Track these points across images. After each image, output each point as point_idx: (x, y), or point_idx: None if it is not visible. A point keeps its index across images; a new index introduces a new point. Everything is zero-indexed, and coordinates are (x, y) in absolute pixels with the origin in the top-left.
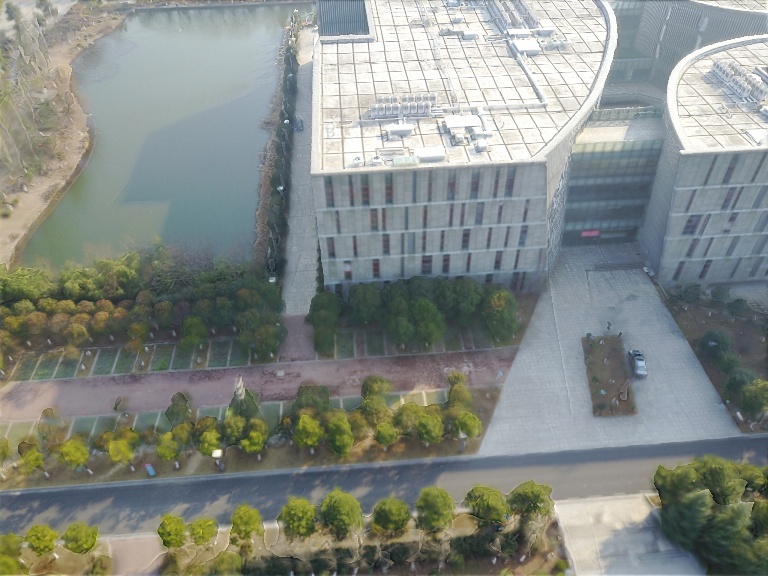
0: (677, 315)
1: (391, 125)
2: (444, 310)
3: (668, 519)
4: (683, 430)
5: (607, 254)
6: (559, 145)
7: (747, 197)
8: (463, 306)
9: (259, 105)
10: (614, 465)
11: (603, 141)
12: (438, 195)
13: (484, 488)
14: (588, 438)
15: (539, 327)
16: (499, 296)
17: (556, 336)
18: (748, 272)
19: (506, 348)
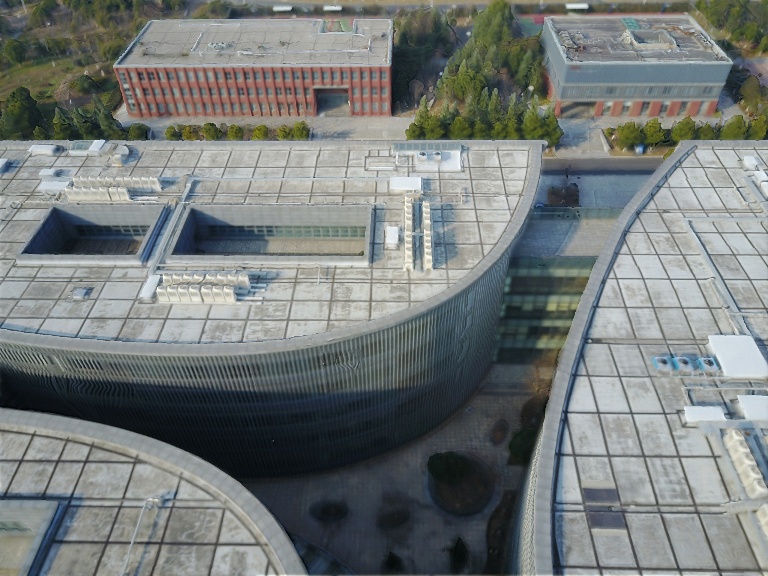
0: None
1: None
2: None
3: None
4: None
5: None
6: None
7: None
8: None
9: None
10: None
11: (603, 208)
12: None
13: (659, 136)
14: (585, 179)
15: None
16: None
17: None
18: None
19: None
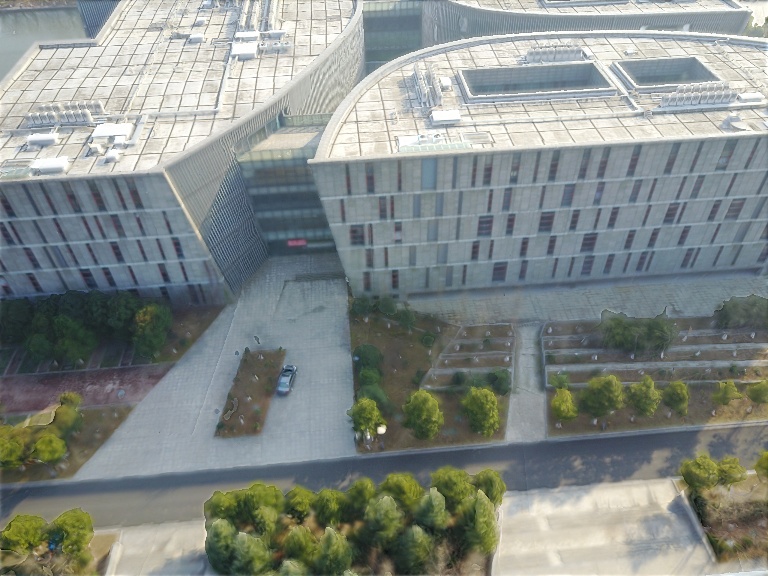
0: (352, 327)
1: (34, 135)
2: (91, 326)
3: (205, 548)
4: (298, 450)
5: (315, 263)
6: (196, 154)
7: (402, 206)
8: (109, 321)
9: None
10: (206, 488)
11: (268, 149)
12: (62, 208)
13: (25, 516)
14: (195, 459)
15: (208, 341)
16: (146, 311)
17: (220, 351)
18: (443, 281)
19: (162, 364)
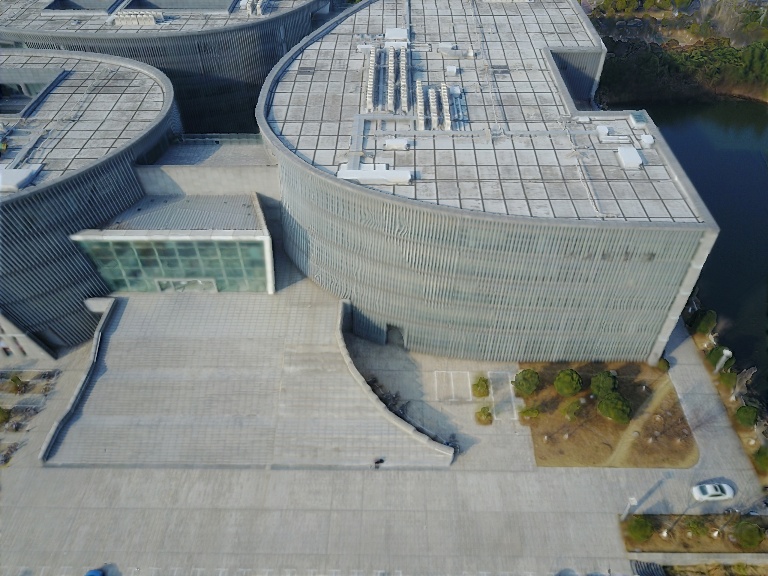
0: None
1: None
2: None
3: None
4: None
5: None
6: None
7: None
8: None
9: (705, 263)
10: None
11: None
12: None
13: None
14: None
15: None
16: None
17: None
18: None
19: None
